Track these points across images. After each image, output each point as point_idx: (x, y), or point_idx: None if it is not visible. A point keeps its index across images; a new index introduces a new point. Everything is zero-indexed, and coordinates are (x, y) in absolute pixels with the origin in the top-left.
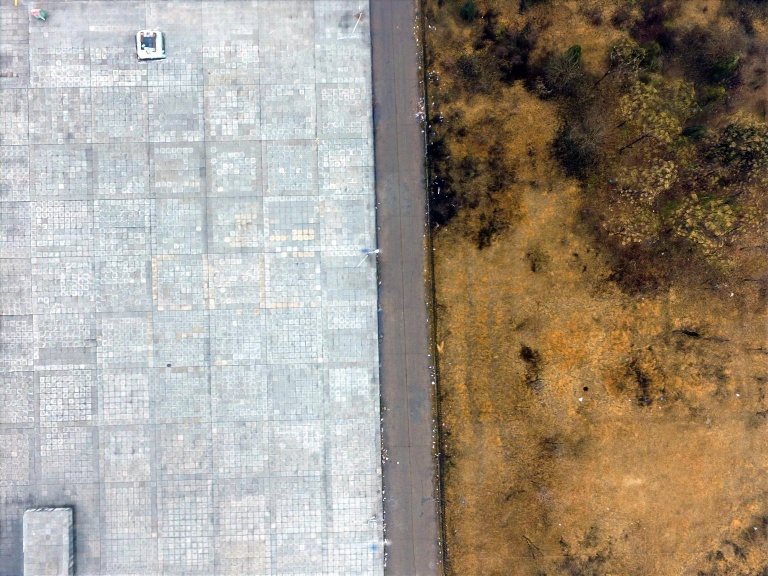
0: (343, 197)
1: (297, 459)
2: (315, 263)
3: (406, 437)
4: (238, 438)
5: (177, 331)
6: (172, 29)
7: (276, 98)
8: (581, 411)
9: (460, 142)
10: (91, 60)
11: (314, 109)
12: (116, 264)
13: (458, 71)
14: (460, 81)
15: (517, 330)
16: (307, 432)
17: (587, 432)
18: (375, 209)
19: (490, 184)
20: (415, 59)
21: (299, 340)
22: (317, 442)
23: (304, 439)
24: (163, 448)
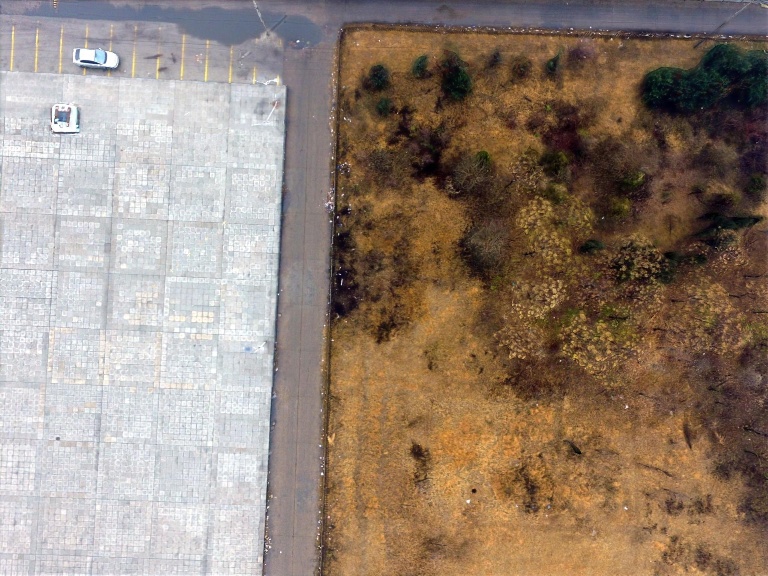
0: (245, 282)
1: (179, 542)
2: (212, 346)
3: (291, 527)
4: (121, 516)
5: (69, 405)
6: (88, 104)
7: (186, 179)
8: (467, 514)
9: (366, 235)
10: (5, 129)
11: (223, 193)
12: (13, 333)
13: (370, 164)
14: (371, 175)
15: (409, 427)
16: (191, 515)
17: (472, 535)
18: (277, 296)
19: (393, 279)
20: (328, 149)
21: (190, 422)
22: (200, 526)
23: (187, 522)
24: (45, 521)
